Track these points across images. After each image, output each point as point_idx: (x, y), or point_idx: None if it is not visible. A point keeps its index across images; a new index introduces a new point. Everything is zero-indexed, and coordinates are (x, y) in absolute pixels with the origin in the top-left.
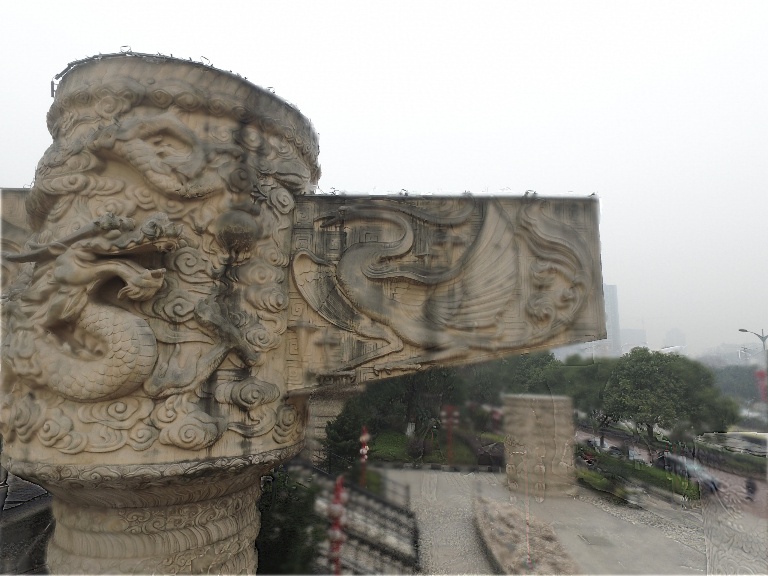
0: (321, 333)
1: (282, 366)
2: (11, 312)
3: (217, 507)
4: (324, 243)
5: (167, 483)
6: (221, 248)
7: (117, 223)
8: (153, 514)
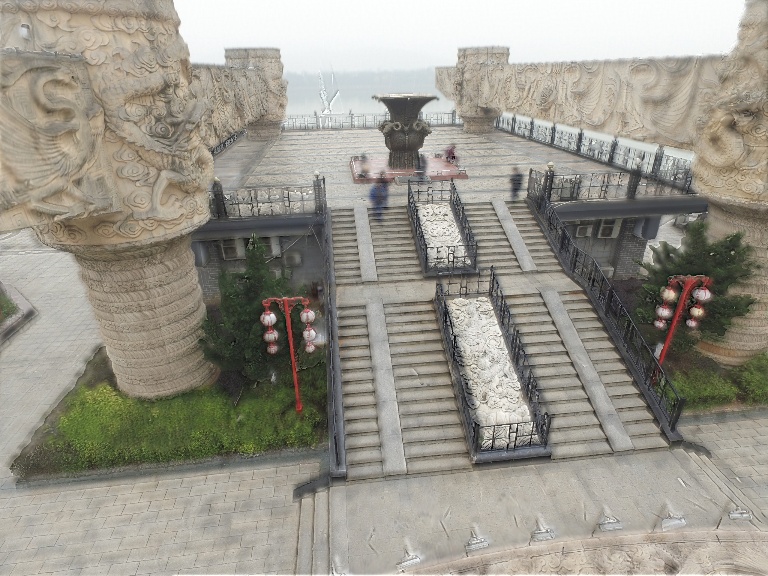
0: None
1: None
2: None
3: None
4: None
5: (738, 205)
6: None
7: (735, 92)
8: (736, 217)
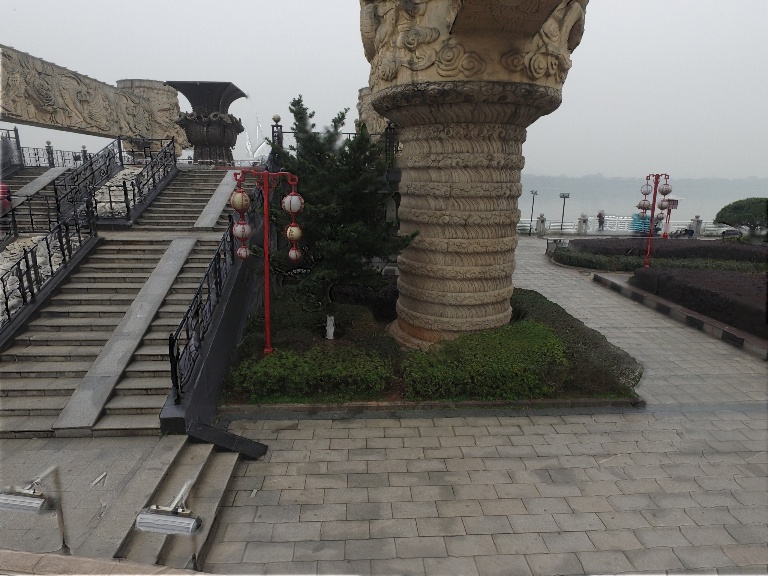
0: None
1: (446, 12)
2: None
3: (432, 129)
4: None
5: (389, 104)
6: None
7: None
8: None
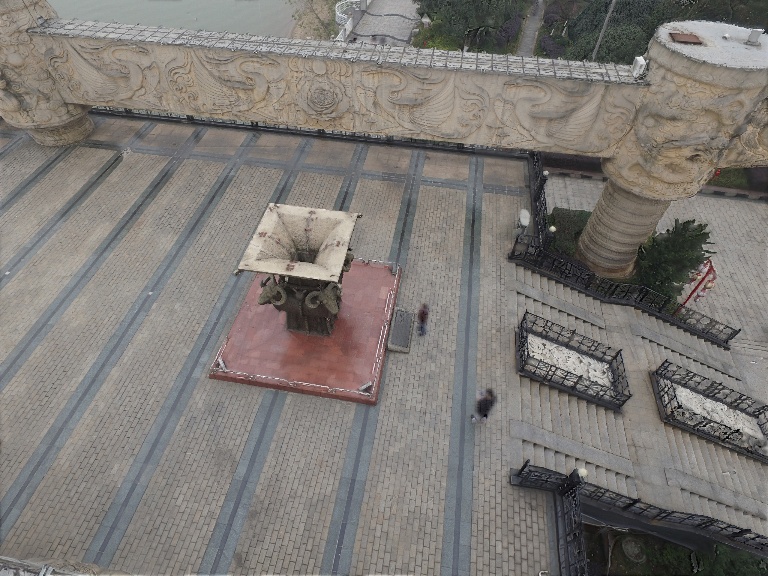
0: (739, 151)
1: None
2: (654, 158)
3: None
4: (761, 118)
5: None
6: (730, 137)
7: None
8: None
